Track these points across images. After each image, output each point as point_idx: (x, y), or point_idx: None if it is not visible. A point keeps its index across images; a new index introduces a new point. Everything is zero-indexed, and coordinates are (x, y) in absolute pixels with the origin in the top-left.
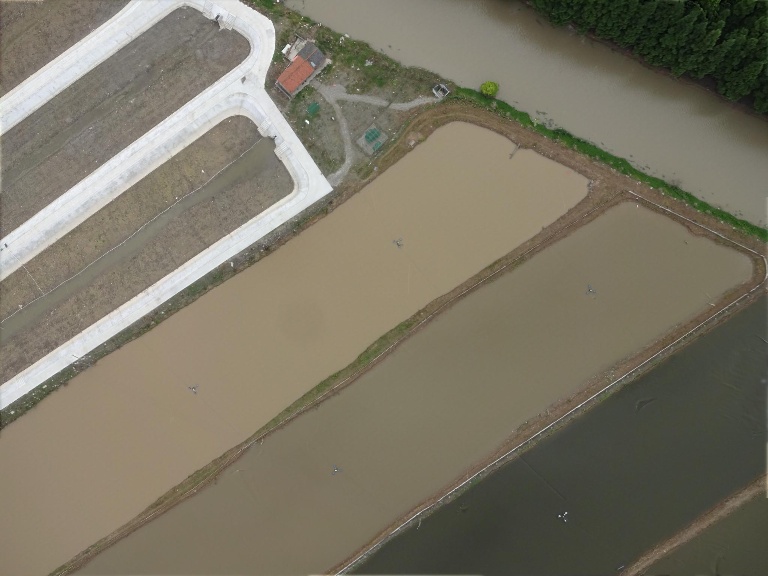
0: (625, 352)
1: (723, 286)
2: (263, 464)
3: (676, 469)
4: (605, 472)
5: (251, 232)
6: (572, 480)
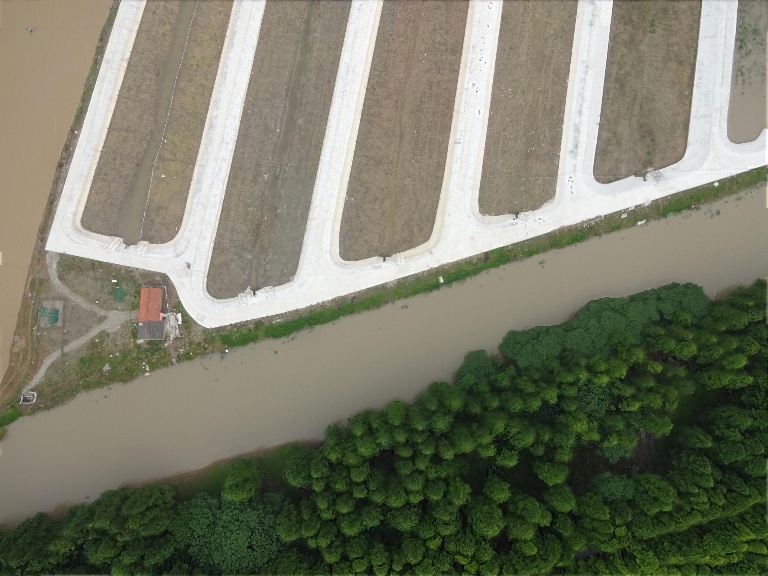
0: None
1: None
2: None
3: None
4: None
5: (81, 166)
6: None
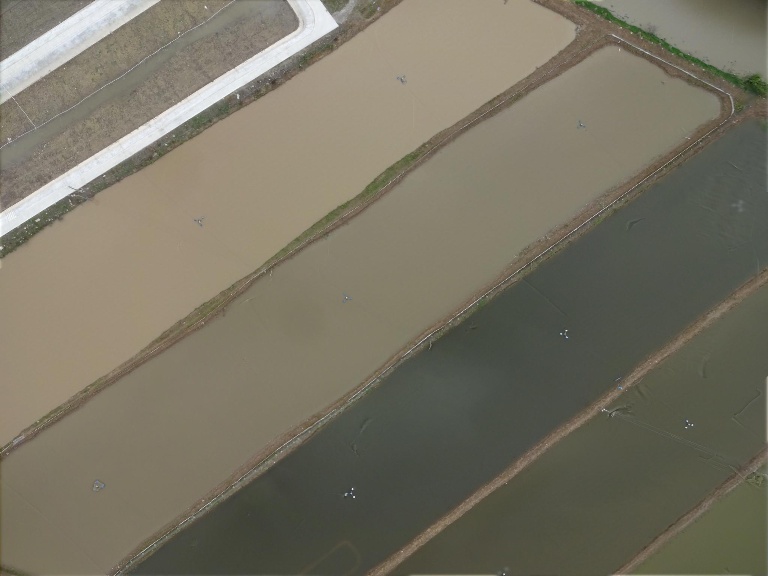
0: (614, 181)
1: (696, 121)
2: (275, 289)
3: (664, 284)
4: (602, 288)
5: (257, 65)
6: (572, 297)
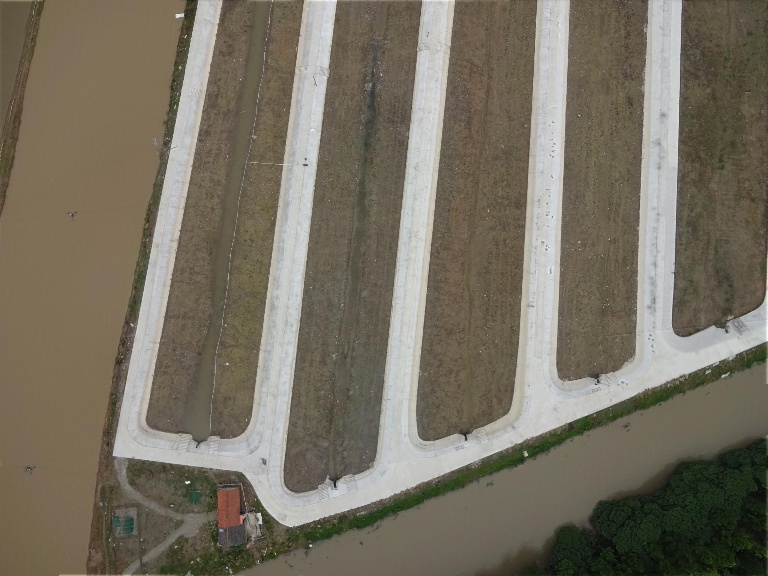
0: None
1: None
2: None
3: None
4: None
5: (141, 362)
6: None
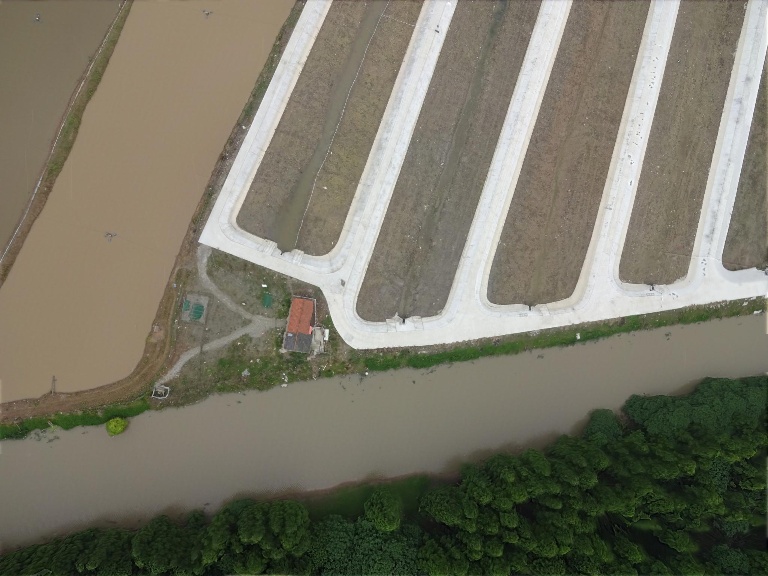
0: None
1: None
2: None
3: None
4: None
5: (246, 162)
6: None
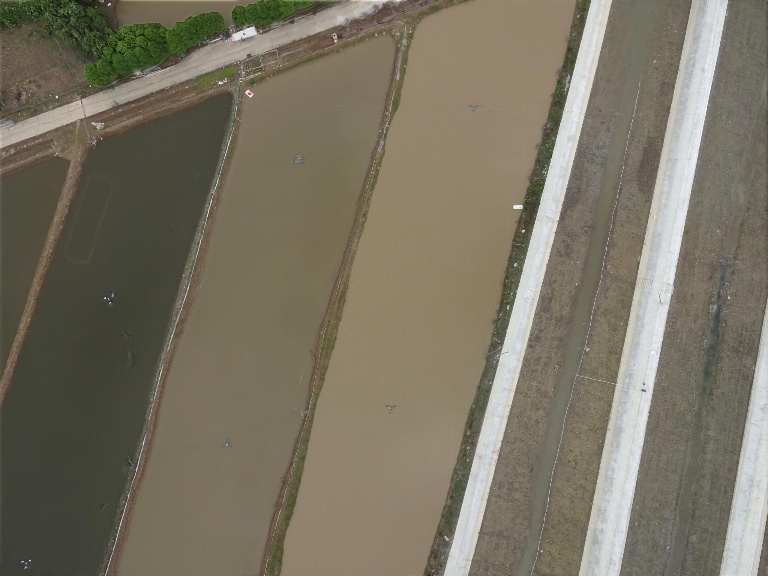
0: None
1: None
2: (284, 405)
3: None
4: None
5: None
6: None
